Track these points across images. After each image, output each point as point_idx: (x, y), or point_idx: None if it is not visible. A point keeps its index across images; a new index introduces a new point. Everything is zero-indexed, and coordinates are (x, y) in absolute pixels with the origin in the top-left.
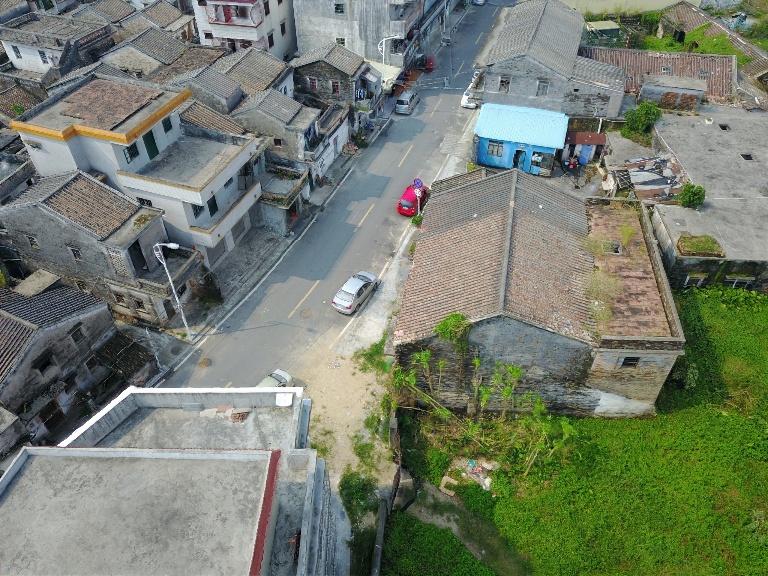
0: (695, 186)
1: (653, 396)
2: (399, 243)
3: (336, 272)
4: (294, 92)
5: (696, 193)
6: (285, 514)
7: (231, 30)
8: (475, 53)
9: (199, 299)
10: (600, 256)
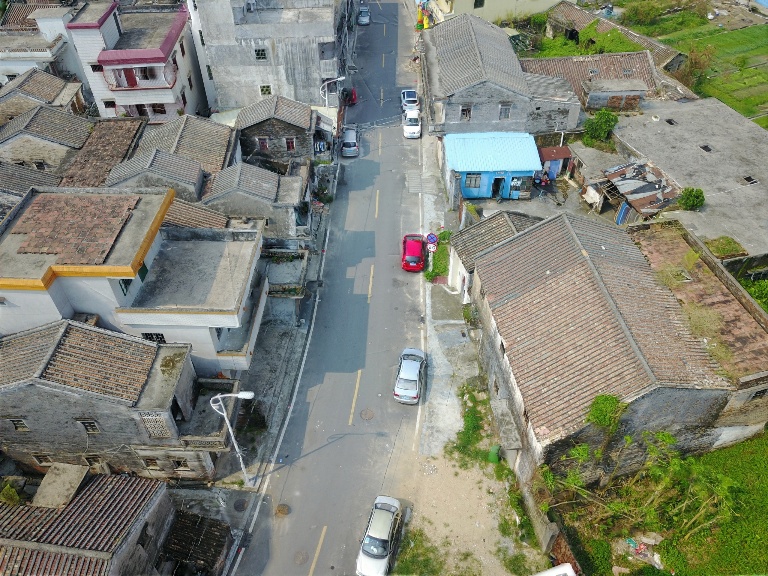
0: (694, 189)
1: (767, 417)
2: (422, 305)
3: (374, 356)
4: (242, 156)
5: (698, 196)
6: None
7: (140, 95)
8: (388, 77)
9: (237, 431)
10: (675, 287)
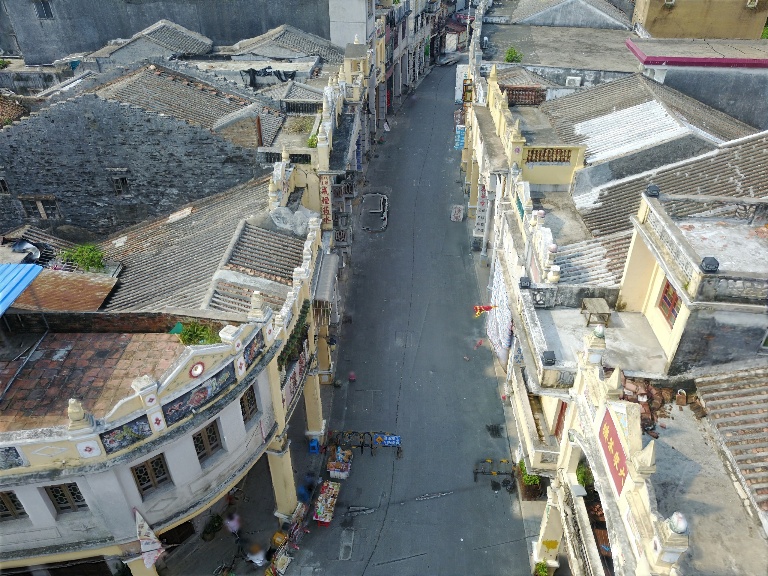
0: None
1: None
2: None
3: None
4: None
5: None
6: None
7: None
8: None
9: None
10: None
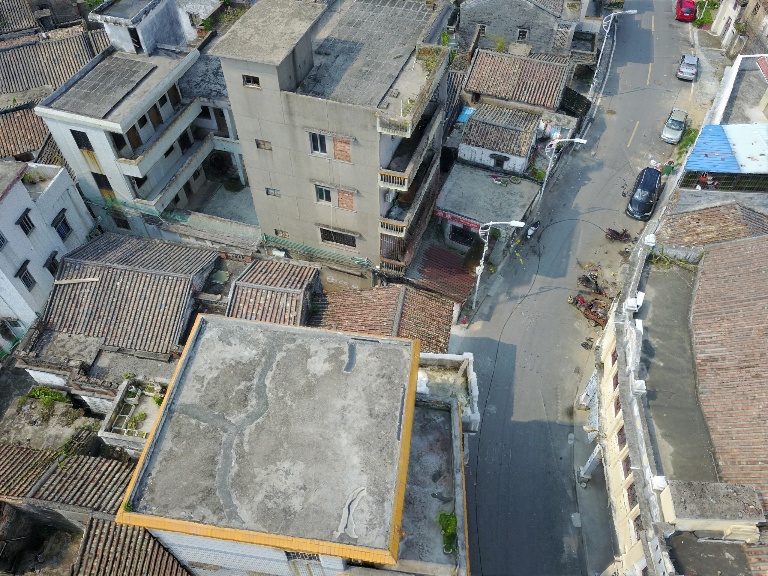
0: None
1: None
2: (691, 39)
3: (659, 58)
4: None
5: None
6: None
7: None
8: None
9: (577, 77)
10: None
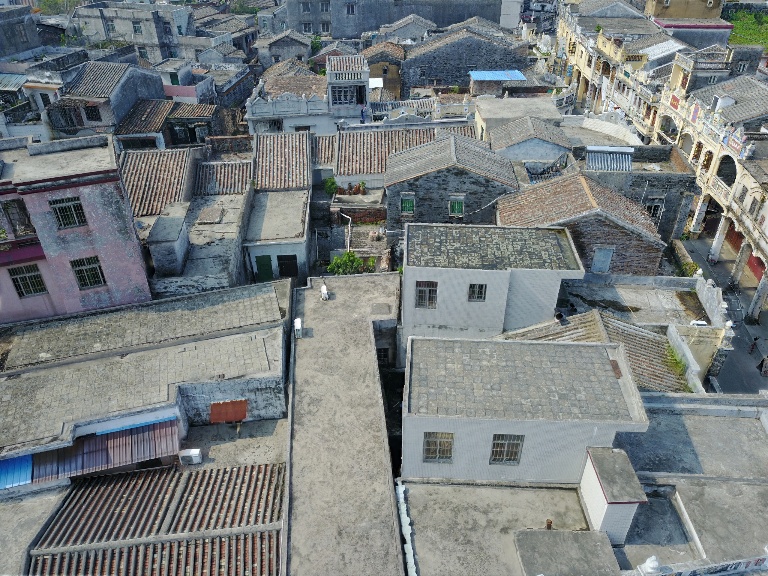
0: None
1: (720, 14)
2: None
3: None
4: None
5: None
6: None
7: None
8: None
9: None
10: None
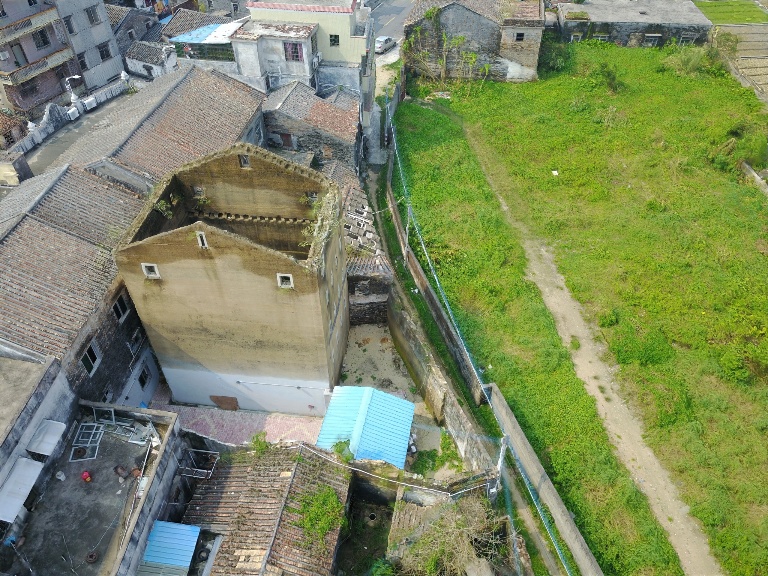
0: None
1: (535, 64)
2: None
3: None
4: None
5: None
6: (359, 26)
7: None
8: None
9: None
10: (513, 2)
